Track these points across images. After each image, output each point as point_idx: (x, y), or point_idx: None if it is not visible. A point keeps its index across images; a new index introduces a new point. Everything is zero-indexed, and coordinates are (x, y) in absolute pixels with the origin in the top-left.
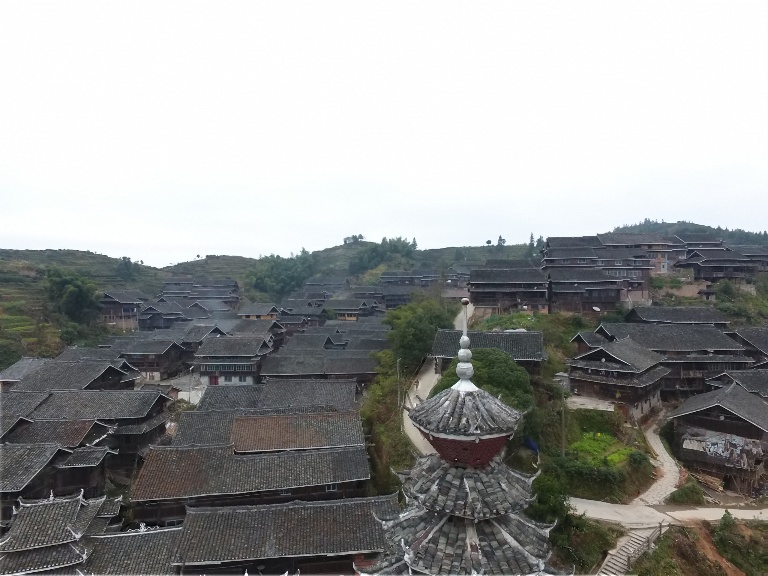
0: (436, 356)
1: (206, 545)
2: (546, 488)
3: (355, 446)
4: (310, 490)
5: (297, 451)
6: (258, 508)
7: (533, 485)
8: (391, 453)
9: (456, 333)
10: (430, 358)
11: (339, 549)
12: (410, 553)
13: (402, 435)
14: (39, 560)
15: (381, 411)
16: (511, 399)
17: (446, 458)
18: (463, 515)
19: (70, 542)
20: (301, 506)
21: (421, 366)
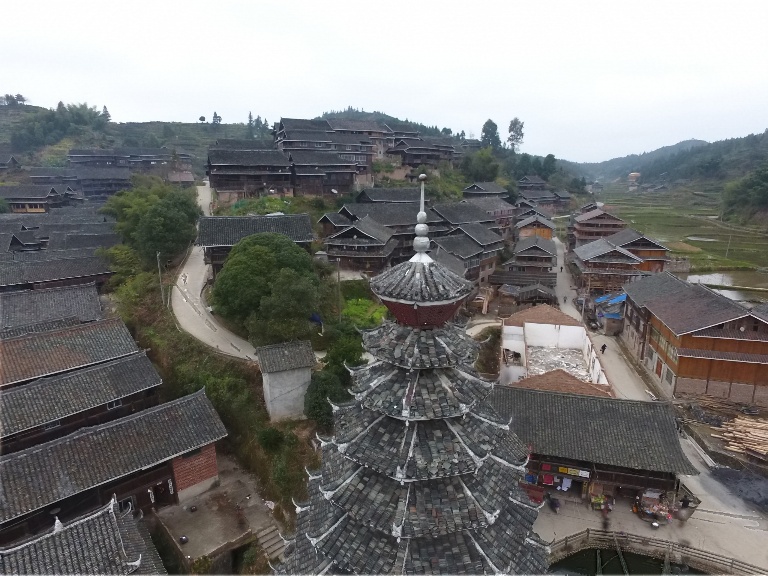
0: (205, 246)
1: None
2: (349, 349)
3: (133, 355)
4: (87, 414)
5: (55, 376)
6: (28, 452)
7: (338, 349)
8: (172, 354)
9: (221, 220)
10: (197, 249)
11: (155, 459)
12: (408, 409)
13: (181, 333)
14: None
15: (142, 313)
16: (307, 278)
17: (416, 324)
18: (449, 365)
19: None
20: (90, 432)
21: (187, 258)
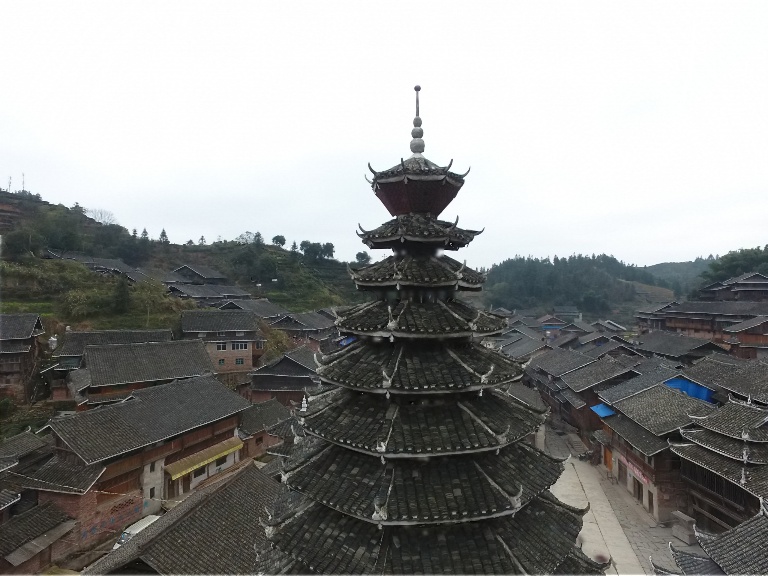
0: None
1: None
2: None
3: None
4: None
5: None
6: None
7: None
8: None
9: None
10: None
11: None
12: None
13: None
14: (719, 444)
15: None
16: None
17: None
18: None
19: (740, 440)
20: None
21: None
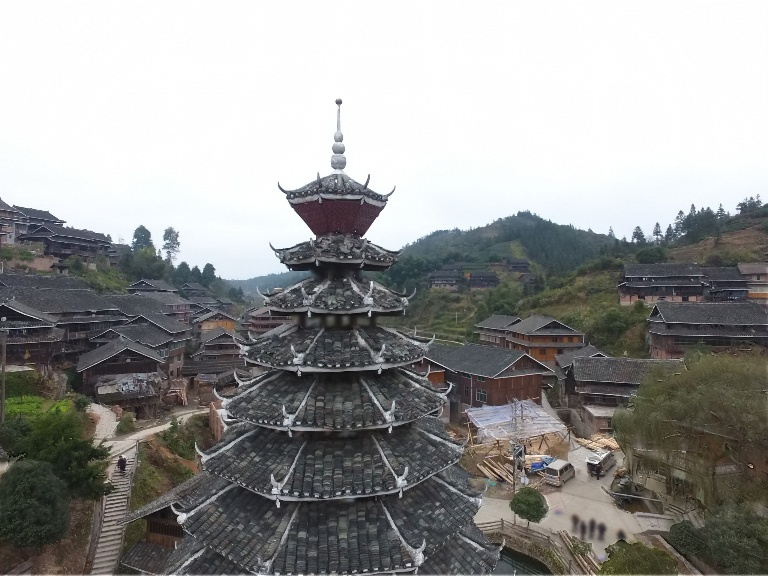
0: None
1: None
2: (61, 426)
3: None
4: None
5: None
6: None
7: (45, 428)
8: None
9: None
10: None
11: None
12: None
13: None
14: None
15: None
16: None
17: (349, 230)
18: (389, 261)
19: None
20: None
21: None
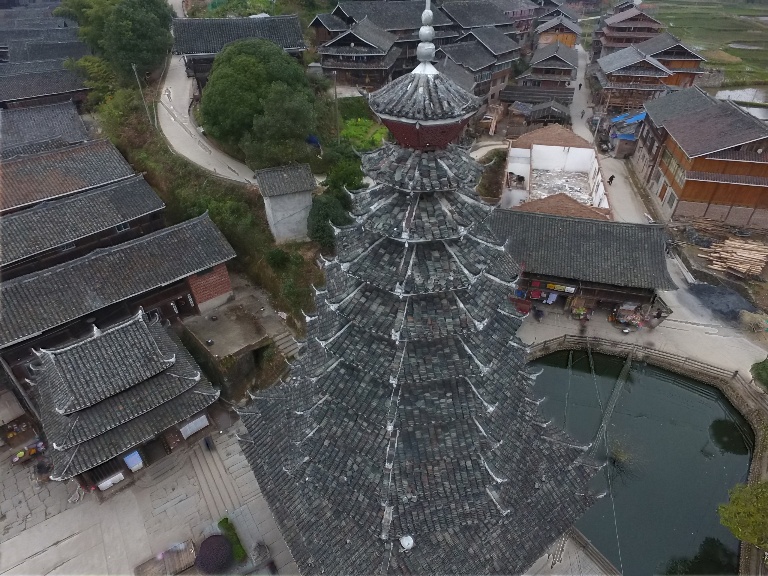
0: (184, 54)
1: (8, 324)
2: (349, 172)
3: (131, 178)
4: (98, 236)
5: (57, 200)
6: (52, 270)
7: (338, 172)
8: (170, 177)
9: (198, 20)
10: (176, 57)
11: (172, 277)
12: (407, 231)
13: (175, 155)
14: None
15: (130, 134)
16: (301, 94)
17: (418, 145)
18: (450, 188)
19: None
20: (106, 253)
21: (167, 70)
